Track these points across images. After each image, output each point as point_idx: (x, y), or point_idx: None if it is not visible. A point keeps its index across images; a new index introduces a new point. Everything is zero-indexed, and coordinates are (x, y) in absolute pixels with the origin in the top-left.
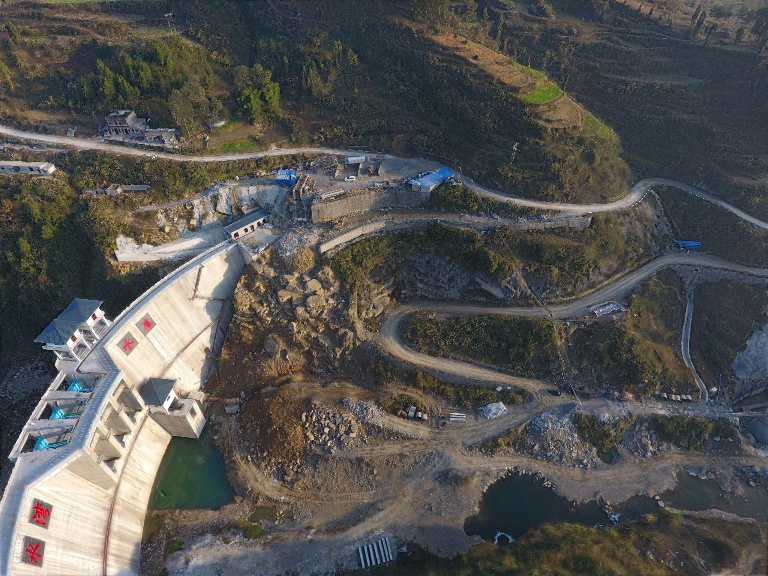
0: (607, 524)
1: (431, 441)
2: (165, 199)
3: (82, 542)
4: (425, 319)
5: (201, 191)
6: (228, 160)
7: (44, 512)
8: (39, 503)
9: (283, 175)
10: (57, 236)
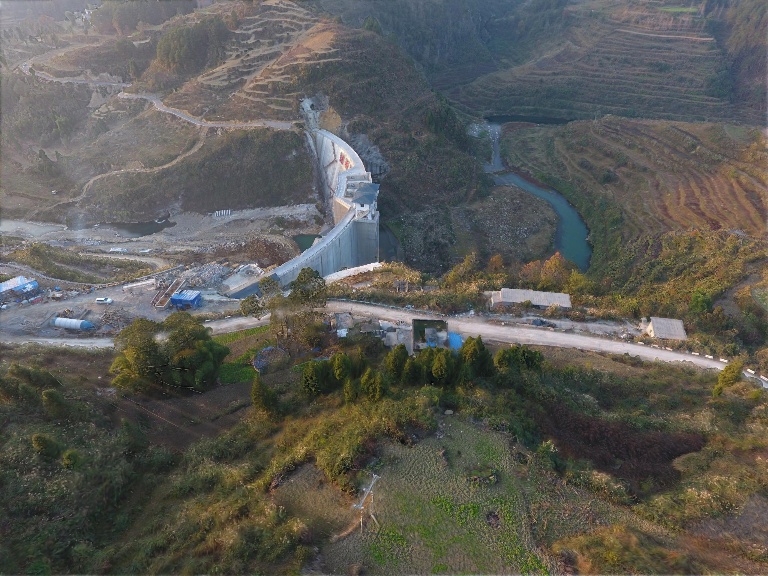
0: (103, 223)
1: (171, 244)
2: None
3: None
4: (125, 264)
5: None
6: None
7: None
8: None
9: (189, 294)
10: None
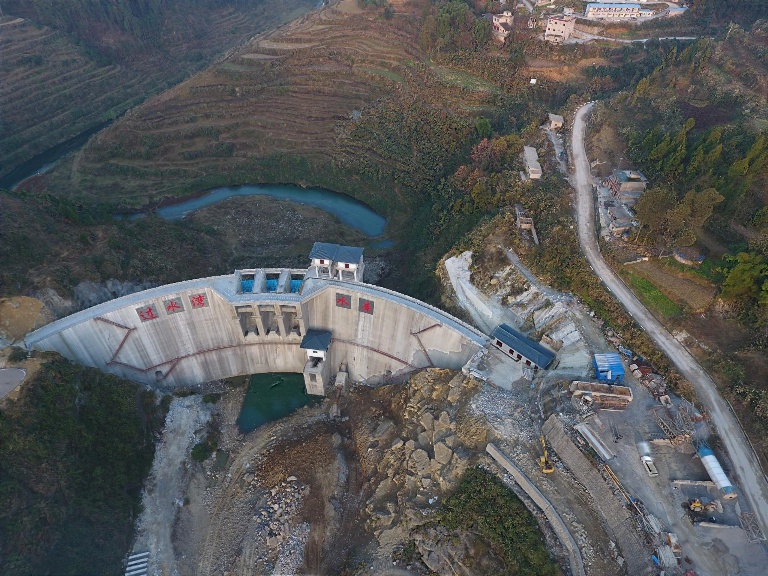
0: None
1: None
2: (530, 263)
3: (200, 334)
4: None
5: (554, 287)
6: (612, 292)
7: (201, 302)
8: (204, 297)
9: (607, 361)
10: (471, 217)
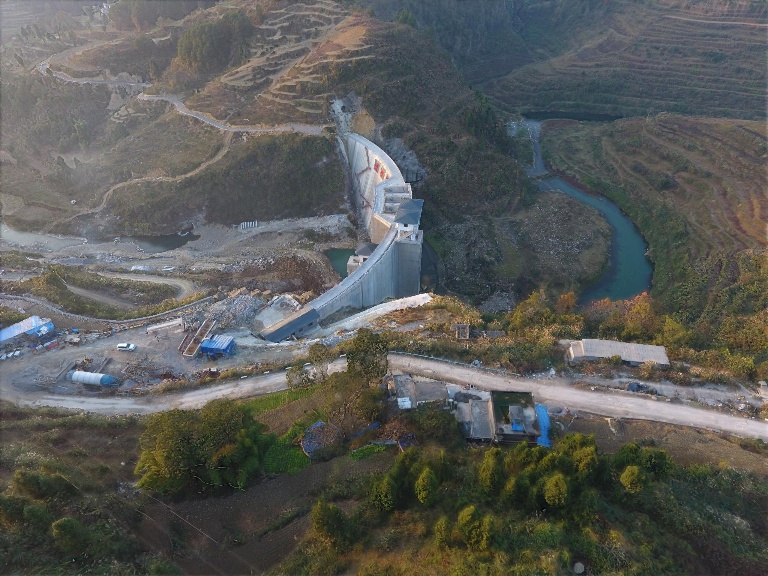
0: (124, 236)
1: (195, 261)
2: None
3: None
4: (148, 288)
5: None
6: None
7: None
8: None
9: (221, 341)
10: None
